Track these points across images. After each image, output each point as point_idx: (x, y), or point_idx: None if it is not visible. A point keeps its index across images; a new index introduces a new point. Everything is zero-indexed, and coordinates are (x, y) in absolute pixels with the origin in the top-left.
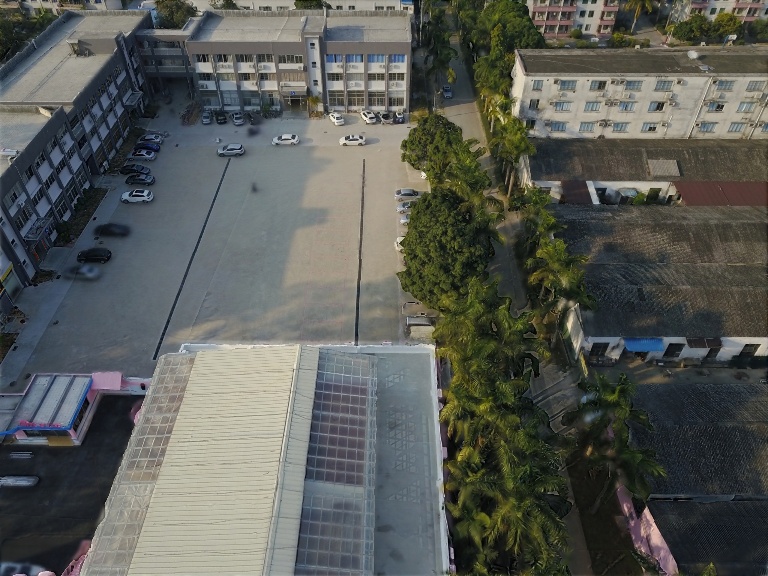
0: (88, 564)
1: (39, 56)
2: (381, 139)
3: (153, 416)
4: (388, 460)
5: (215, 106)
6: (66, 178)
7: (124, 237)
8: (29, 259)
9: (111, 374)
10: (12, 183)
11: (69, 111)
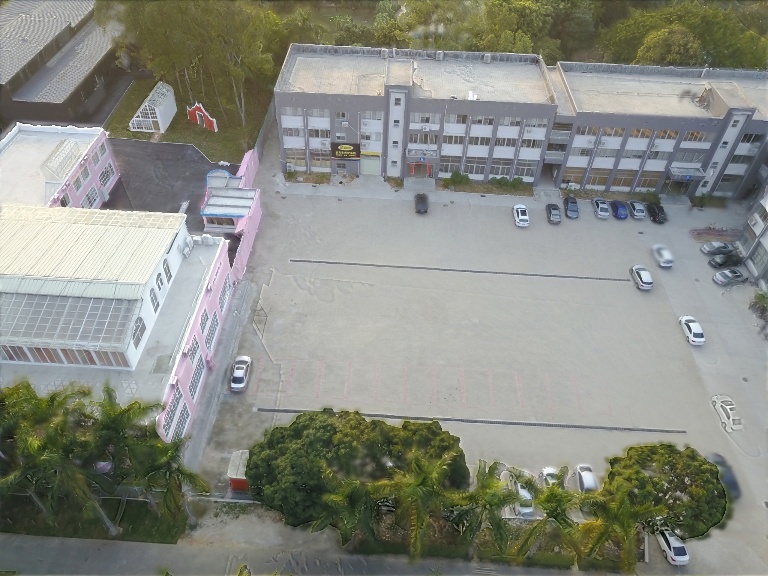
0: (19, 206)
1: (685, 82)
2: (760, 459)
3: (123, 217)
4: (39, 378)
5: (745, 251)
6: (505, 154)
7: (456, 218)
8: (401, 165)
9: (244, 223)
10: (432, 110)
11: (565, 115)
